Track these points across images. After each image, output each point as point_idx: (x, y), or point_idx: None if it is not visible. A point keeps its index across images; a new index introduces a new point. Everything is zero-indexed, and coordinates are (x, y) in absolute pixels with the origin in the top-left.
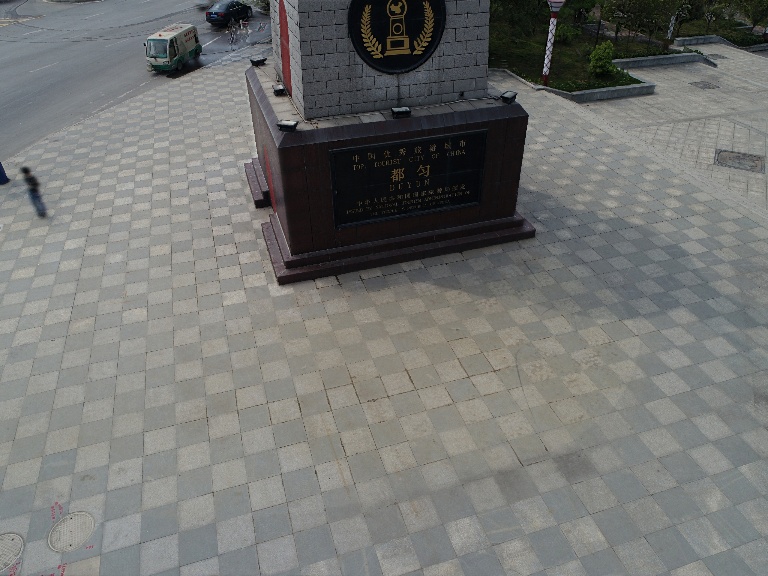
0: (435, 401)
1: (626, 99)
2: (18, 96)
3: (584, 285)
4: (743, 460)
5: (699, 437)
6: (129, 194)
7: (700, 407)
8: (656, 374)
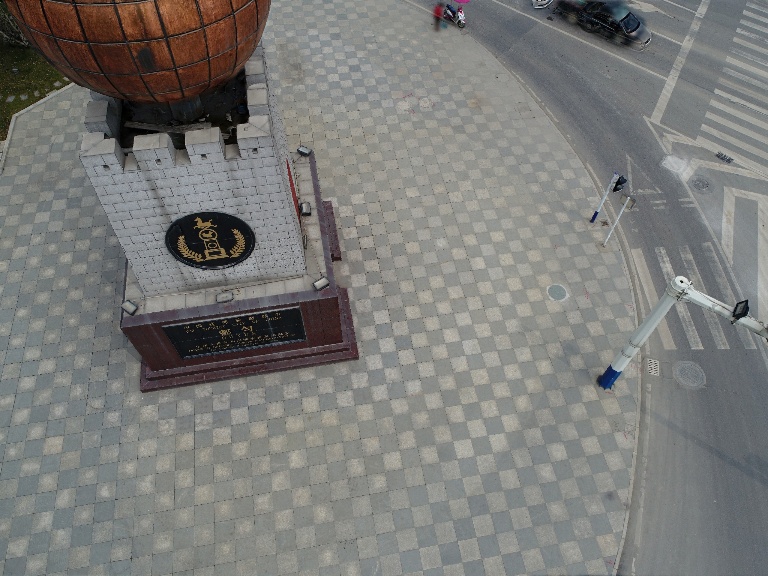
0: None
1: None
2: None
3: None
4: None
5: None
6: (462, 330)
7: None
8: None
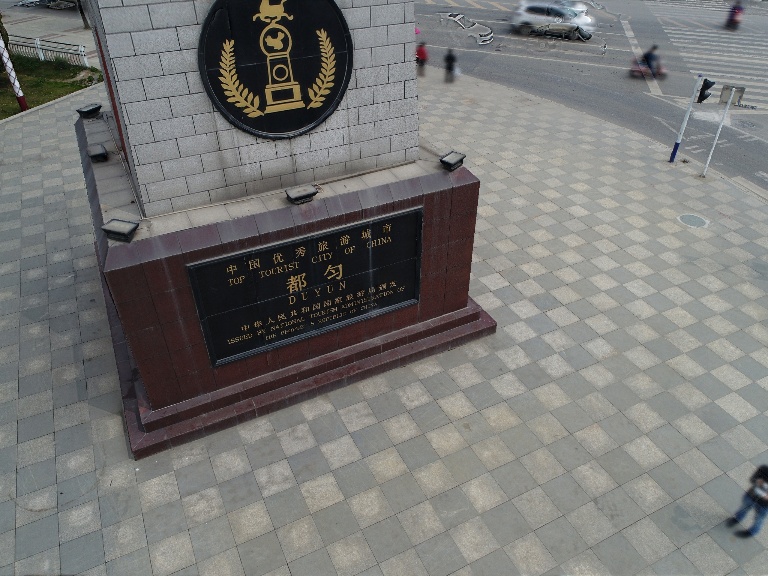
0: None
1: None
2: None
3: (89, 209)
4: None
5: None
6: (613, 274)
7: None
8: None
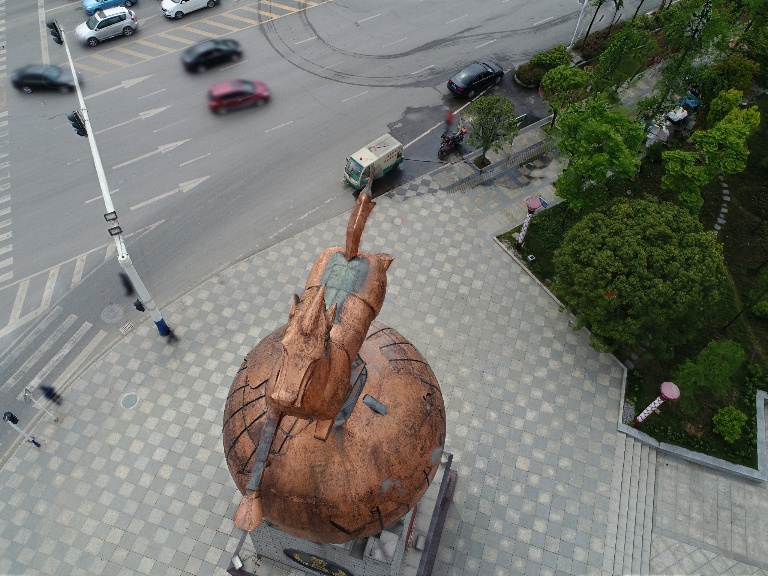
0: None
1: (718, 477)
2: (237, 179)
3: None
4: None
5: None
6: (218, 407)
7: None
8: None
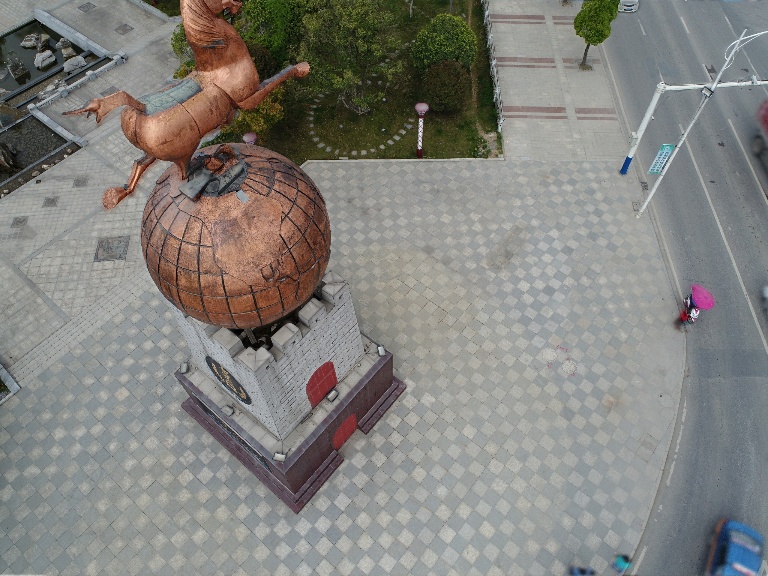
0: (431, 293)
1: None
2: None
3: None
4: (397, 215)
5: (395, 225)
6: (377, 570)
7: (381, 227)
8: (372, 240)
